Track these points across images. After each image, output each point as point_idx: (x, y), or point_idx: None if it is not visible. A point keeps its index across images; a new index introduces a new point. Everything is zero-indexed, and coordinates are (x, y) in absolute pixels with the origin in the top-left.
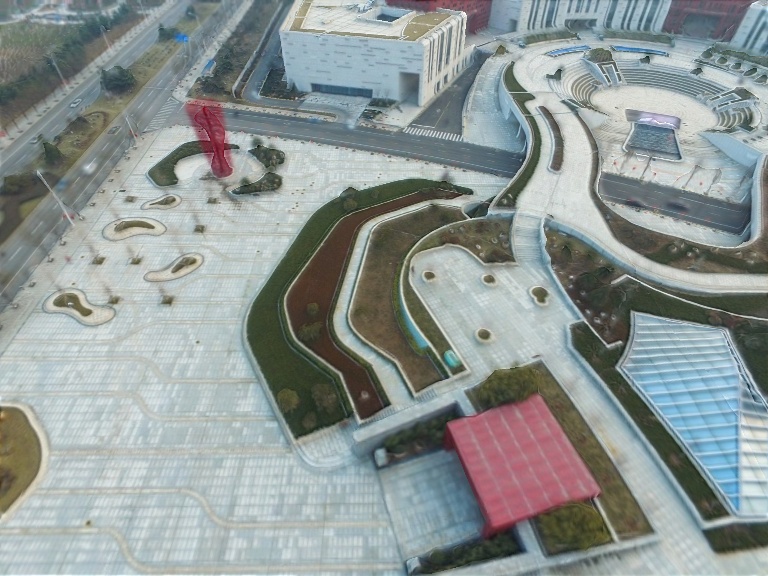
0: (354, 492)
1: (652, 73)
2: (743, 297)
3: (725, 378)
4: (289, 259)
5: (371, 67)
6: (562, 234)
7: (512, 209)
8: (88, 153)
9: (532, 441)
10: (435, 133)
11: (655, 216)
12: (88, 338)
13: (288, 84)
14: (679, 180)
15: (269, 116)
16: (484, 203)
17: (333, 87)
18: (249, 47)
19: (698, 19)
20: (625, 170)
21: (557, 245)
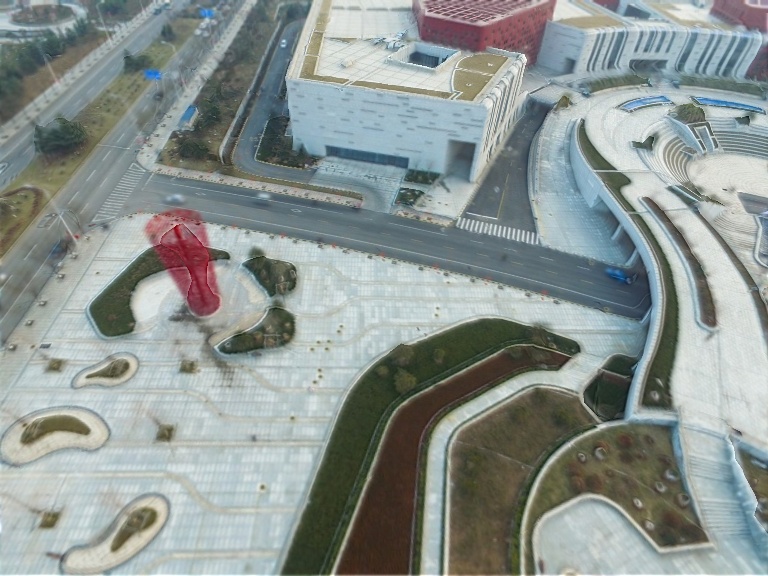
0: None
1: (753, 138)
2: None
3: None
4: (316, 512)
5: (410, 131)
6: (759, 465)
7: (669, 412)
8: (2, 265)
9: None
10: (500, 229)
11: None
12: None
13: (294, 144)
14: None
15: (270, 197)
16: (603, 373)
17: (355, 151)
18: (241, 84)
19: None
20: None
21: (765, 499)
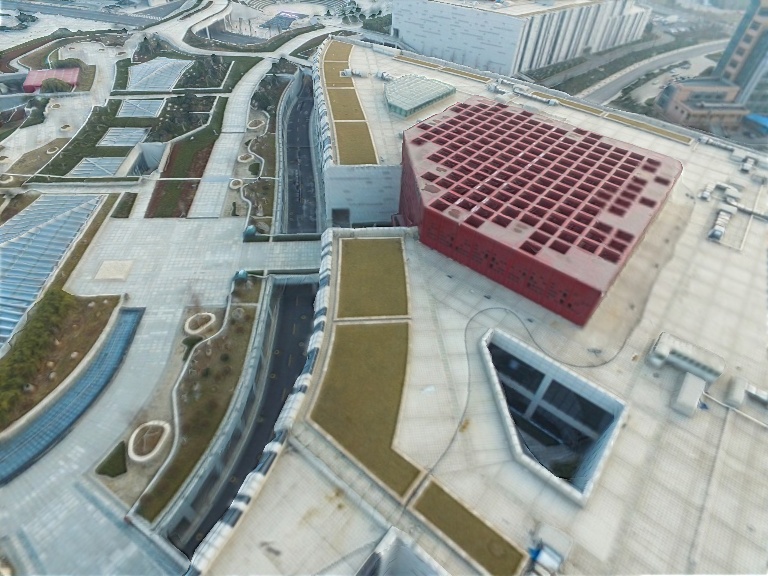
0: None
1: None
2: None
3: None
4: (8, 49)
5: None
6: None
7: None
8: None
9: None
10: (147, 16)
11: None
12: None
13: None
14: (266, 34)
15: (42, 6)
16: None
17: None
18: None
19: None
20: (243, 31)
21: (150, 42)
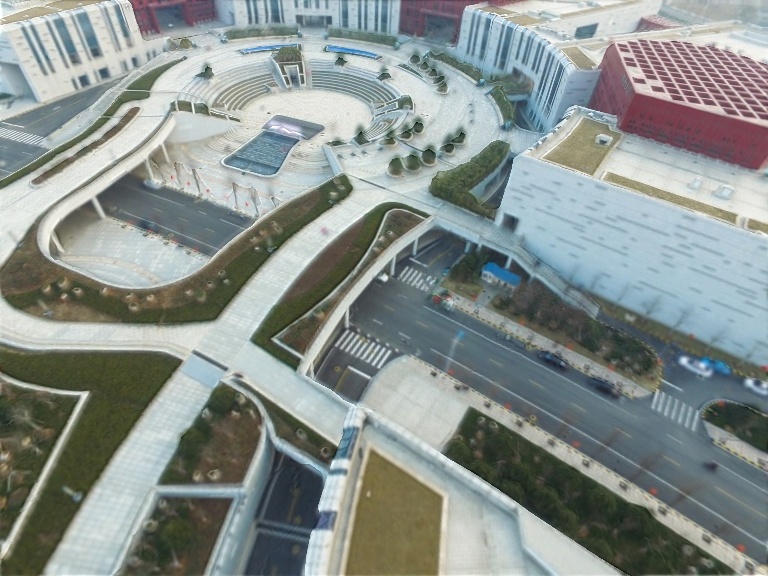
0: None
1: (343, 76)
2: (67, 356)
3: None
4: None
5: None
6: None
7: None
8: None
9: None
10: (15, 134)
11: (158, 242)
12: None
13: None
14: (229, 199)
15: None
16: None
17: None
18: None
19: (445, 22)
20: (183, 185)
21: None
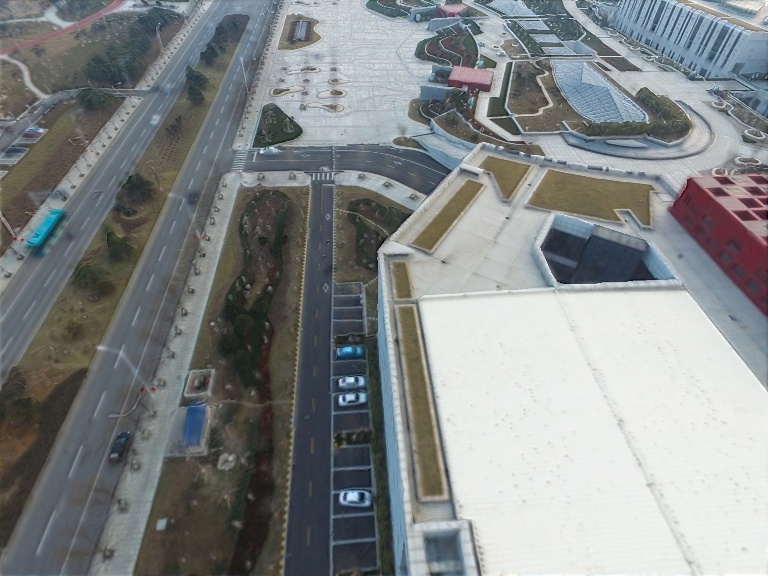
0: (411, 24)
1: None
2: None
3: (516, 1)
4: None
5: None
6: None
7: None
8: None
9: (460, 7)
10: None
11: None
12: (313, 8)
13: None
14: None
15: None
16: None
17: None
18: None
19: None
20: None
21: None
